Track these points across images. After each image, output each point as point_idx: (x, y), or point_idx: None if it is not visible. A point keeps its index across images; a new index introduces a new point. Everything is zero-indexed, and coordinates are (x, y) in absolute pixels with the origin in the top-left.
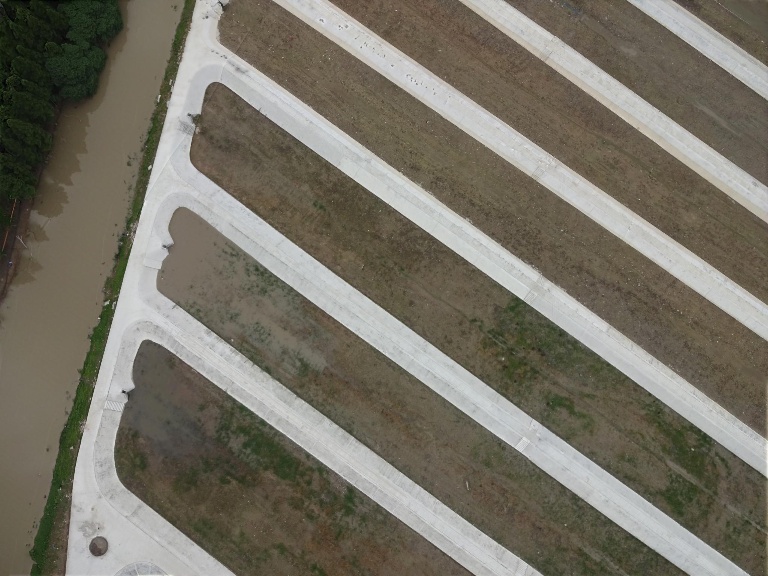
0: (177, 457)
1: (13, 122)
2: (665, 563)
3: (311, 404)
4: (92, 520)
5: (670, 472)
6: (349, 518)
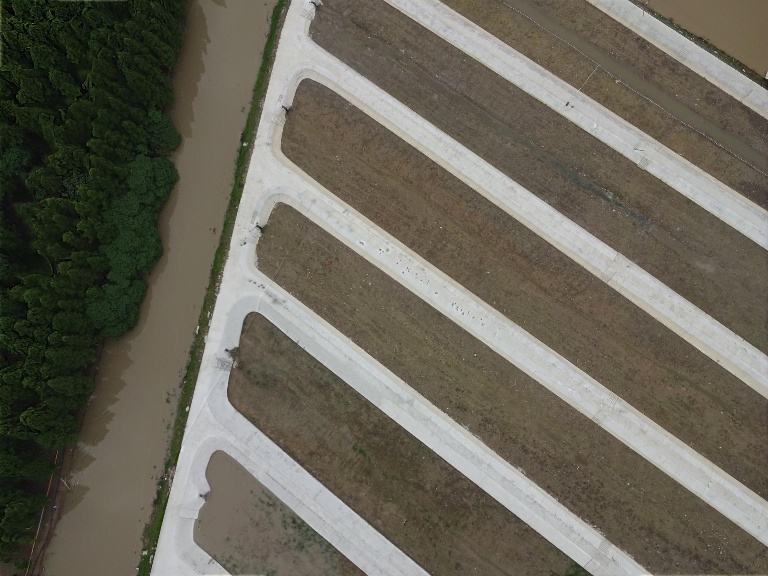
0: None
1: (54, 383)
2: None
3: None
4: None
5: None
6: None
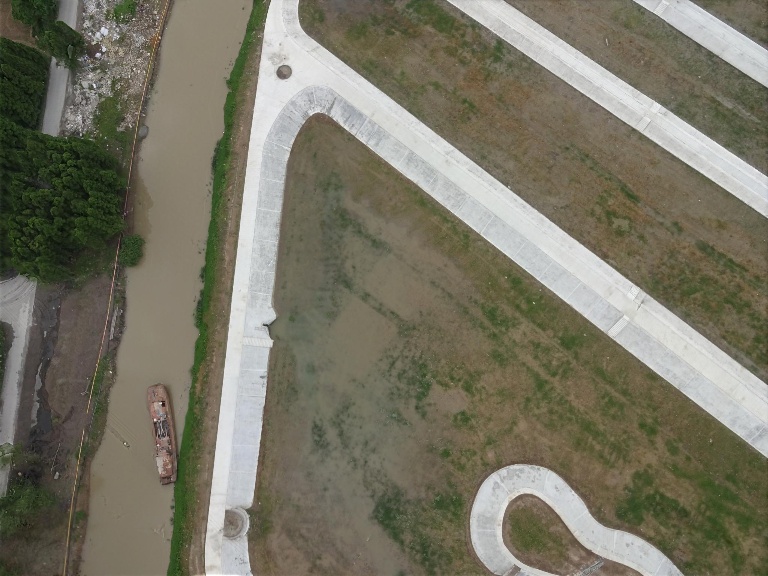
0: (350, 14)
1: None
2: None
3: None
4: (279, 53)
5: None
6: (497, 64)
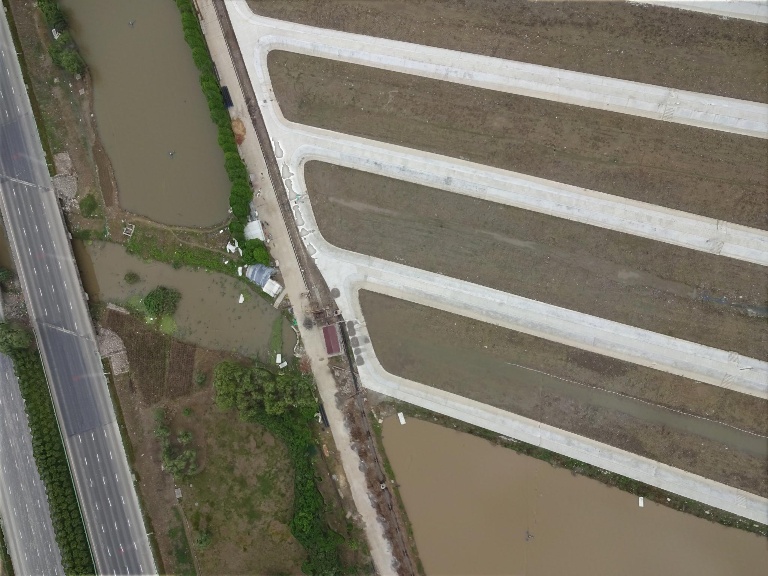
0: None
1: None
2: None
3: None
4: None
5: None
6: None
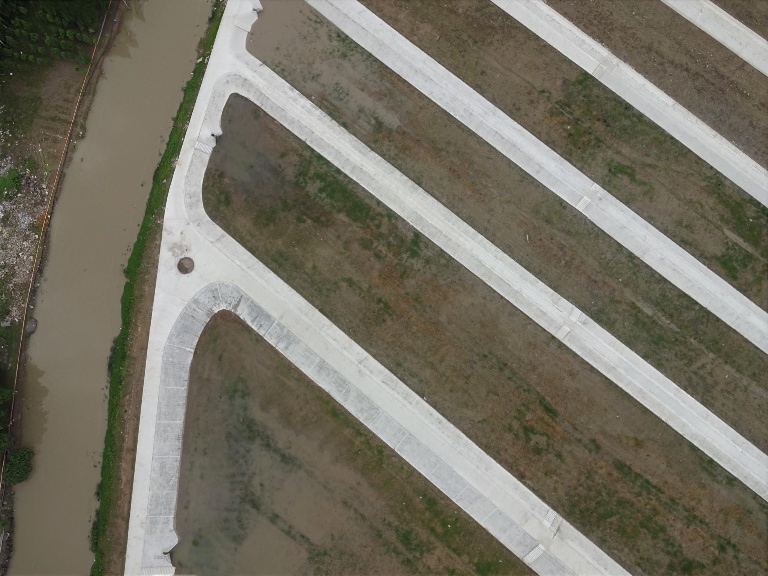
0: (258, 197)
1: None
2: (716, 320)
3: (384, 157)
4: (181, 243)
5: (727, 240)
6: (414, 260)
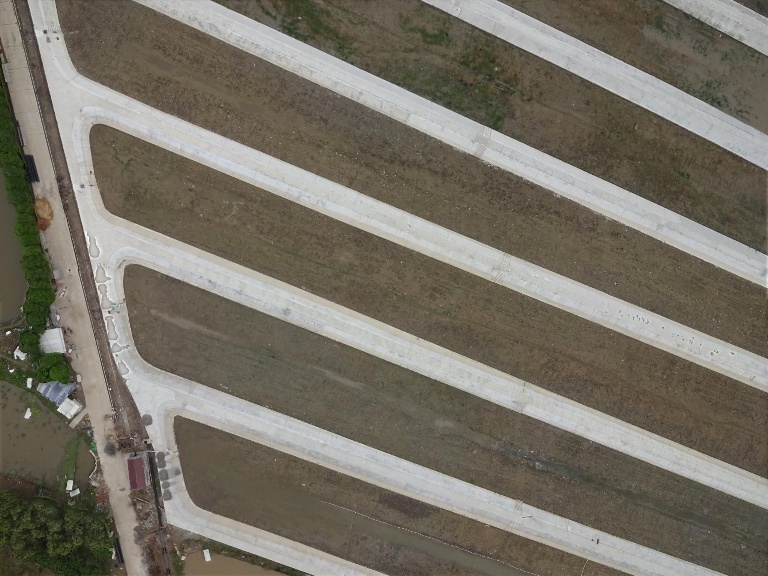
0: None
1: None
2: None
3: None
4: None
5: None
6: None
